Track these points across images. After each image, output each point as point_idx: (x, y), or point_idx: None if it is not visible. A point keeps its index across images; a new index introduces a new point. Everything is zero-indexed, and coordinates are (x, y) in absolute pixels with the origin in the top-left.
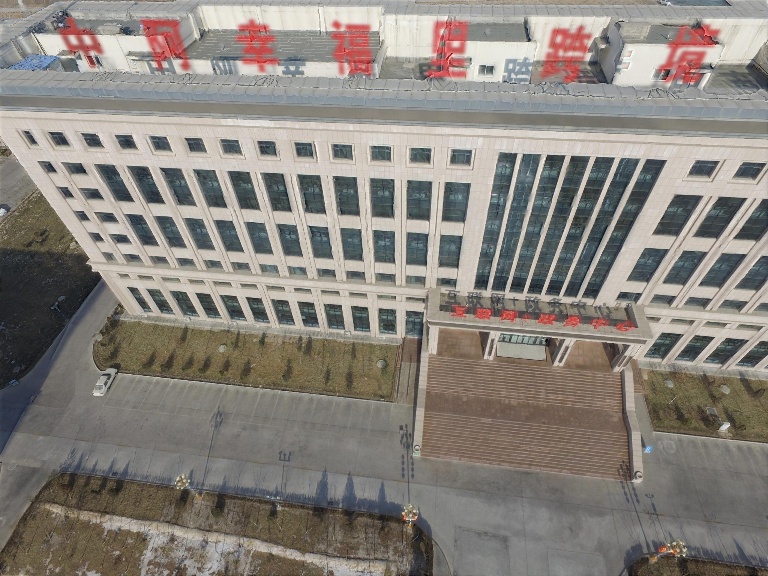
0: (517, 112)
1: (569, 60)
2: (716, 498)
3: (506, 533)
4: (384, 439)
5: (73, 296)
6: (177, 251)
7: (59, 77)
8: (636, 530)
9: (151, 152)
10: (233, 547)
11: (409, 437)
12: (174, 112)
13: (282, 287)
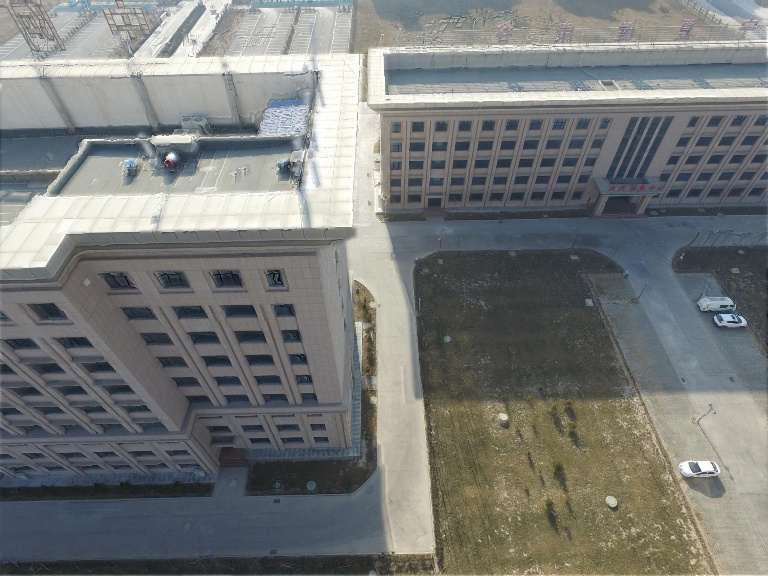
0: None
1: None
2: None
3: None
4: None
5: (435, 342)
6: None
7: (190, 65)
8: None
9: None
10: None
11: None
12: None
13: None
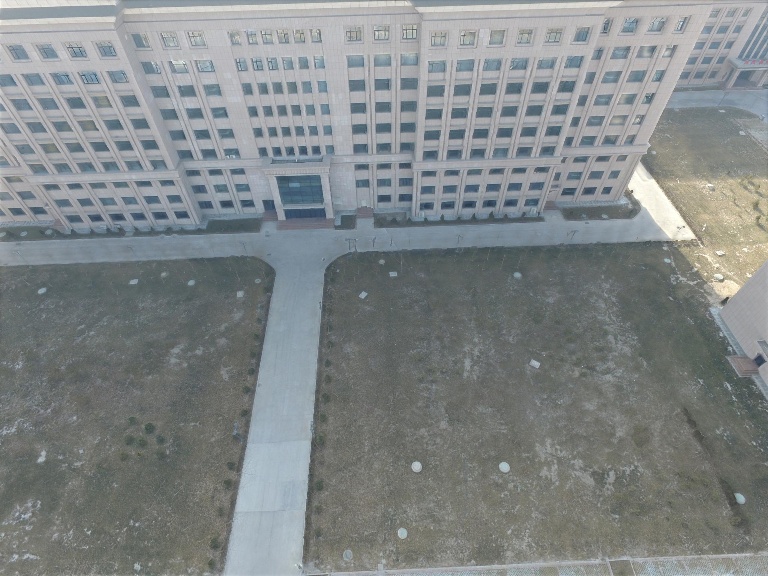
0: None
1: (265, 16)
2: None
3: None
4: None
5: (647, 153)
6: None
7: None
8: None
9: None
10: None
11: None
12: None
13: None
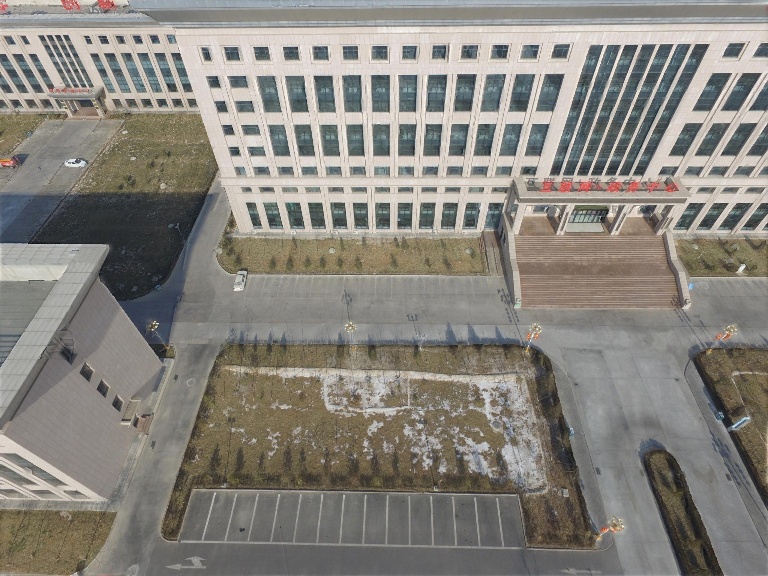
0: (616, 5)
1: None
2: (744, 313)
3: (599, 348)
4: (488, 299)
5: (181, 223)
6: (304, 160)
7: None
8: (692, 337)
9: (310, 61)
10: (392, 378)
11: (507, 297)
12: (346, 21)
13: (388, 189)
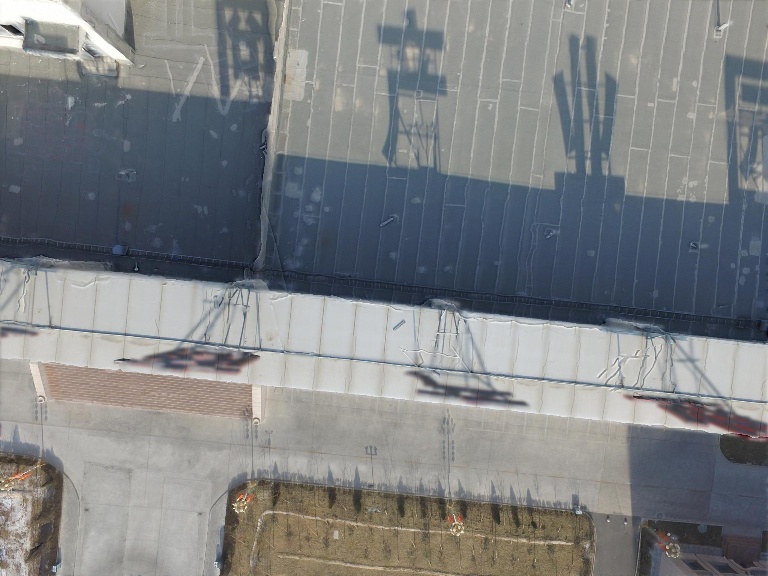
0: None
1: None
2: (329, 433)
3: (130, 467)
4: (16, 382)
5: None
6: None
7: None
8: (246, 461)
9: None
10: None
11: None
12: None
13: None
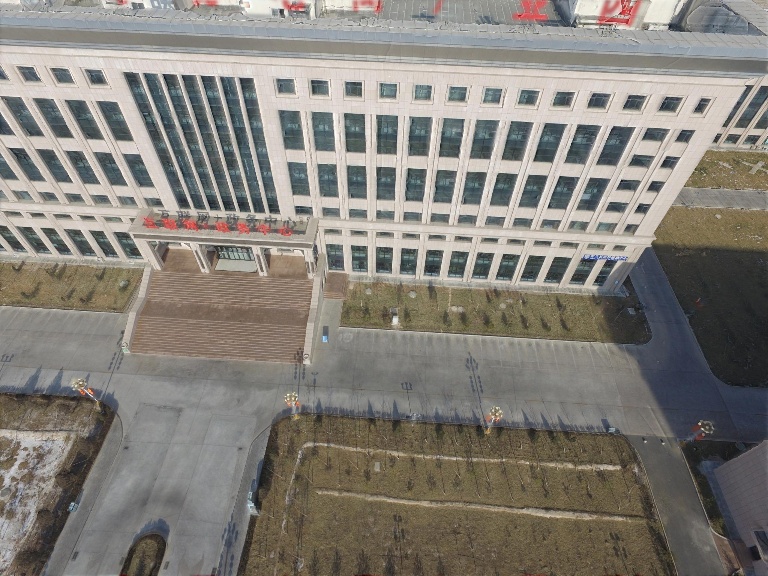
0: (96, 30)
1: (236, 5)
2: (368, 372)
3: (182, 406)
4: (103, 341)
5: None
6: None
7: None
8: None
9: None
10: None
11: None
12: None
13: (19, 213)
